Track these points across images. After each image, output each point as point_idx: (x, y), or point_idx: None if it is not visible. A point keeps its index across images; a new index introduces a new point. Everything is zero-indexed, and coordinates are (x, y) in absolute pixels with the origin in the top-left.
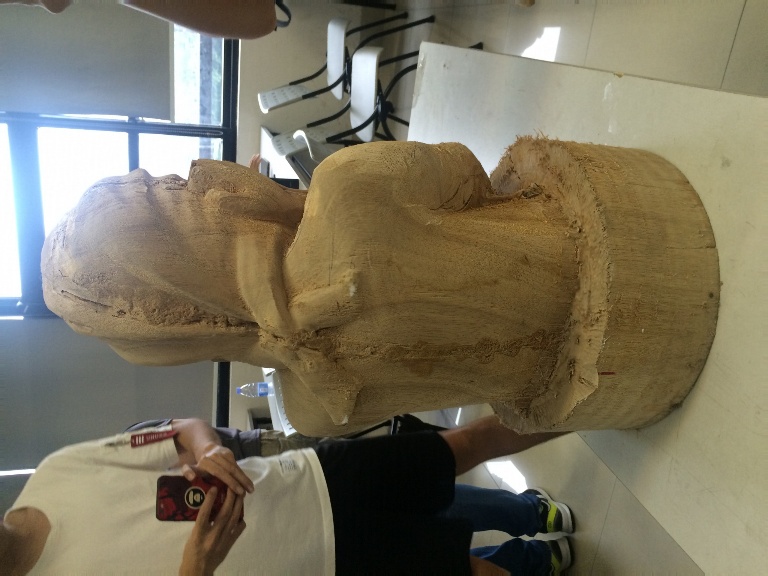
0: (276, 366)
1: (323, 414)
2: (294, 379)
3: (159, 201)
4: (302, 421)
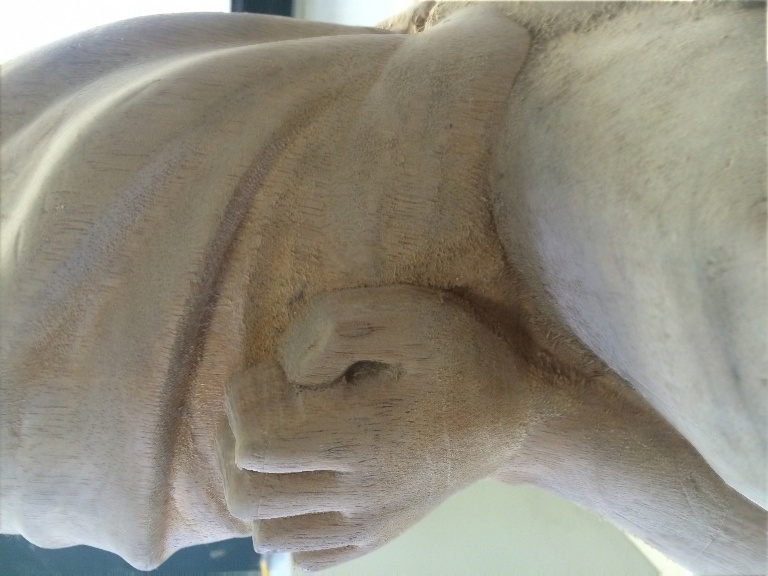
0: (496, 38)
1: (728, 25)
2: (568, 55)
3: None
4: (716, 115)
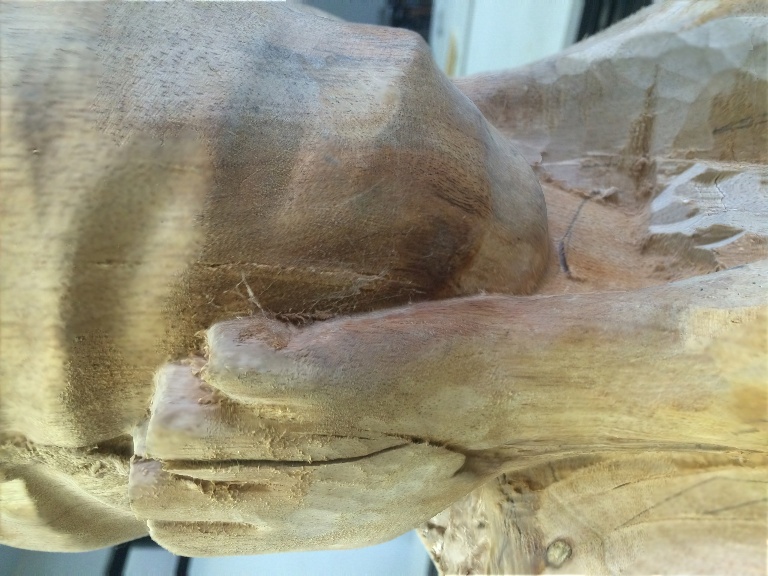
0: None
1: None
2: None
3: (86, 499)
4: None
